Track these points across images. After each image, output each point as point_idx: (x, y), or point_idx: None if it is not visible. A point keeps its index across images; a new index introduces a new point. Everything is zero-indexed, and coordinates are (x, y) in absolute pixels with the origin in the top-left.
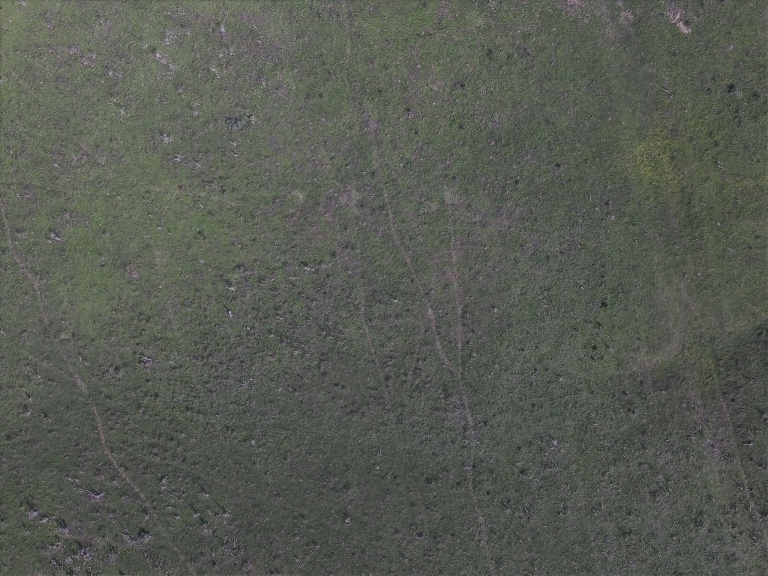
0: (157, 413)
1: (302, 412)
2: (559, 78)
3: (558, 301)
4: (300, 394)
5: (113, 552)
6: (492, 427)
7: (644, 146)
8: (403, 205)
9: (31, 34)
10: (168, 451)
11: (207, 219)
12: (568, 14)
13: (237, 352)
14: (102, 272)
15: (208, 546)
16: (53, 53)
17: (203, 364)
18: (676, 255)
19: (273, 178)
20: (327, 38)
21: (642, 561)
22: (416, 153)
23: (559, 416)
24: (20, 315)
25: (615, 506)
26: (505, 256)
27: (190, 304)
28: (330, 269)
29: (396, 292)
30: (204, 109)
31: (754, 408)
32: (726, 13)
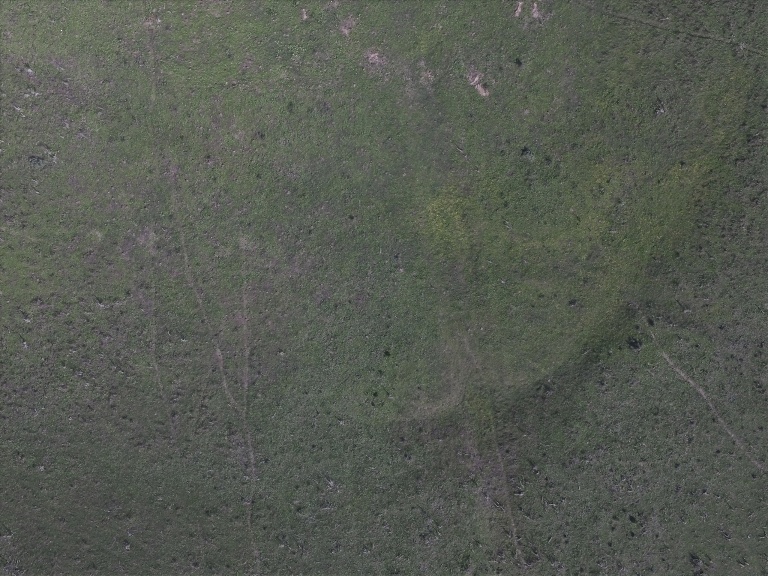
0: None
1: (91, 442)
2: (356, 133)
3: (344, 348)
4: (89, 425)
5: None
6: (273, 465)
7: (437, 203)
8: (199, 248)
9: None
10: None
11: (7, 252)
12: (369, 71)
13: (31, 381)
14: None
15: None
16: None
17: None
18: (460, 310)
19: (73, 216)
20: (132, 83)
21: None
22: (214, 199)
23: (338, 458)
24: None
25: (386, 547)
26: (295, 302)
27: None
28: (124, 306)
29: (186, 332)
30: (8, 146)
31: (526, 460)
32: (523, 78)
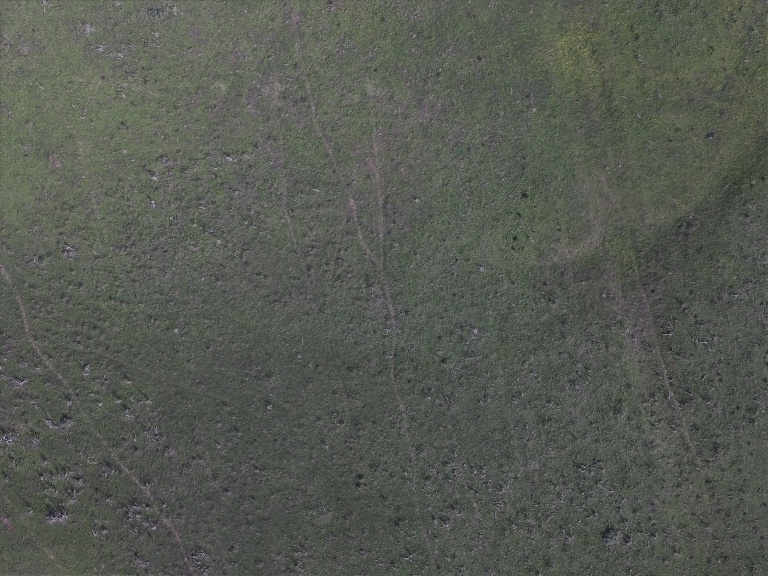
0: (81, 302)
1: (225, 302)
2: None
3: (479, 192)
4: (223, 284)
5: (35, 437)
6: (413, 317)
7: (566, 40)
8: (325, 97)
9: None
10: (91, 339)
11: (130, 109)
12: None
13: (160, 242)
14: (25, 162)
15: (130, 432)
16: None
17: (126, 254)
18: (597, 147)
19: (195, 69)
20: None
21: (561, 448)
22: (338, 45)
23: (480, 306)
24: None
25: (535, 394)
26: (427, 148)
27: (113, 194)
28: (252, 160)
29: (318, 182)
30: None
31: (673, 298)
32: None
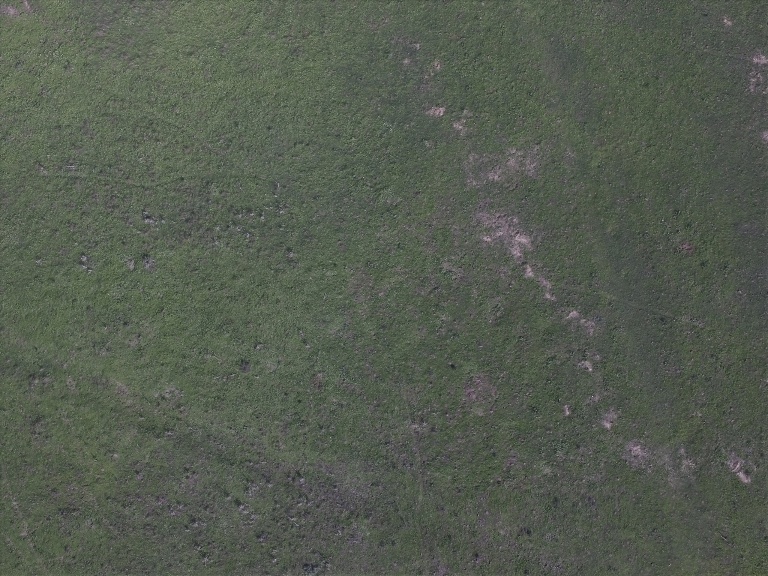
0: None
1: None
2: (622, 526)
3: None
4: None
5: None
6: None
7: None
8: None
9: (122, 482)
10: None
11: None
12: (632, 464)
13: None
14: None
15: None
16: (142, 502)
17: None
18: None
19: None
20: (400, 486)
21: None
22: None
23: None
24: None
25: None
26: None
27: None
28: None
29: None
30: (282, 555)
31: None
32: None
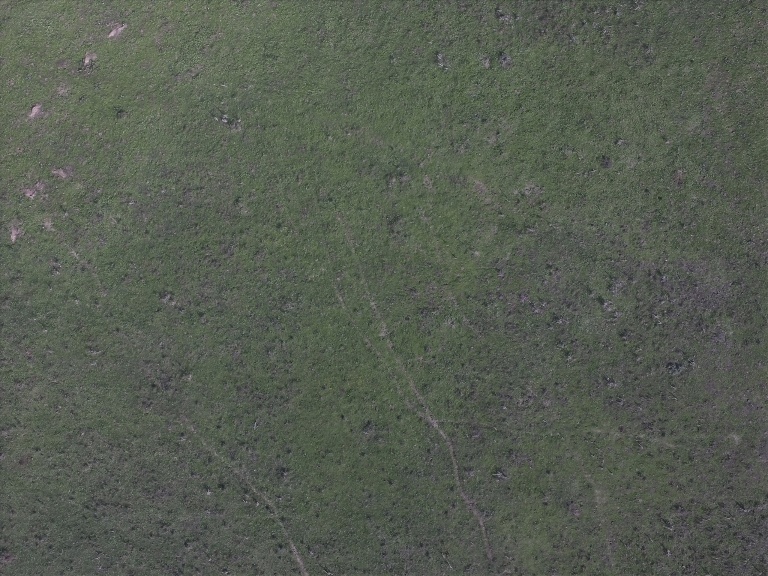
0: None
1: None
2: None
3: None
4: None
5: None
6: None
7: None
8: None
9: (482, 281)
10: None
11: (646, 460)
12: None
13: None
14: (545, 510)
15: None
16: (503, 300)
17: None
18: None
19: (710, 421)
20: (762, 284)
21: None
22: None
23: None
24: (466, 550)
25: None
26: None
27: (628, 542)
28: (765, 510)
29: None
30: (646, 354)
31: None
32: None
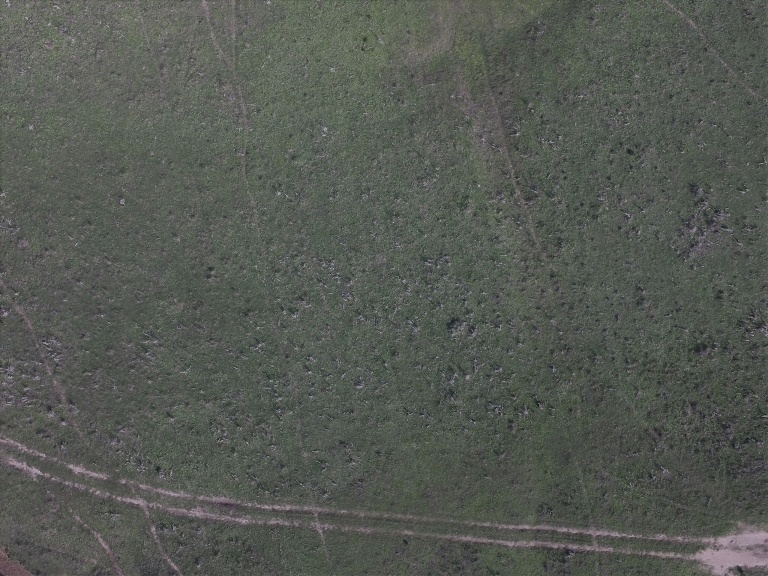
0: None
1: (80, 100)
2: None
3: None
4: (77, 82)
5: None
6: (265, 116)
7: None
8: None
9: None
10: None
11: None
12: None
13: (16, 41)
14: None
15: None
16: None
17: None
18: None
19: None
20: None
21: (409, 243)
22: None
23: (330, 105)
24: None
25: (383, 191)
26: None
27: None
28: None
29: None
30: None
31: (520, 100)
32: None
